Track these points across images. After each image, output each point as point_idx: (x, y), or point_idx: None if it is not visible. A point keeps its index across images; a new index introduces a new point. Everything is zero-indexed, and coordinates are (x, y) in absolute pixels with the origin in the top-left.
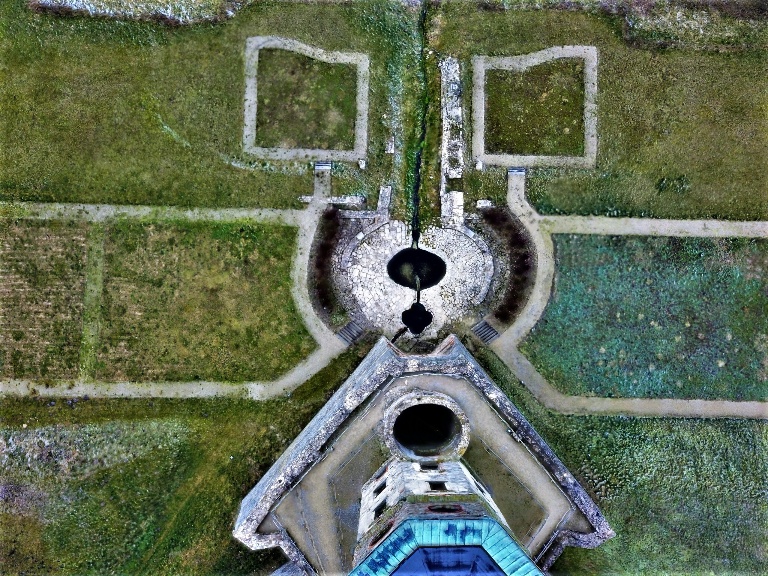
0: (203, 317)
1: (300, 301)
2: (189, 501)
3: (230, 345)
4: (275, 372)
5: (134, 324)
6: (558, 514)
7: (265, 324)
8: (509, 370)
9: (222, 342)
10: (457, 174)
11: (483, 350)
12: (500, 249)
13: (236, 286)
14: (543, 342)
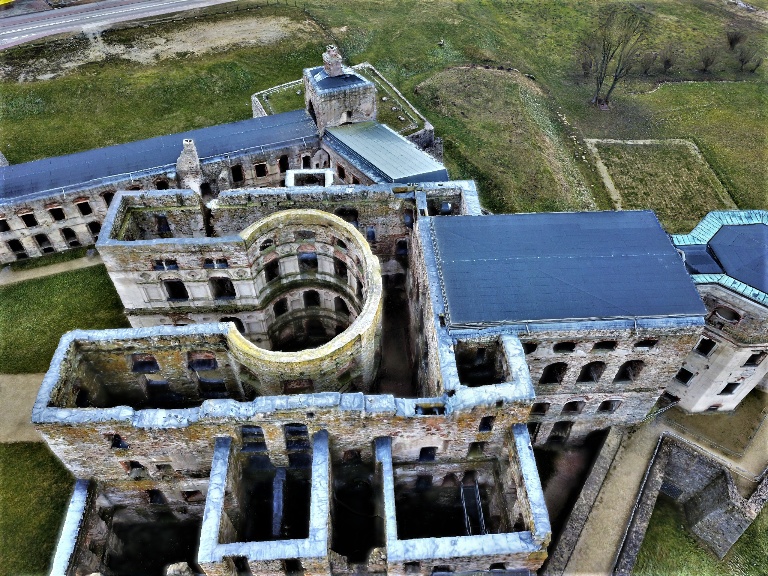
0: None
1: None
2: None
3: None
4: None
5: None
6: None
7: None
8: None
9: None
10: None
11: None
12: None
13: None
14: None
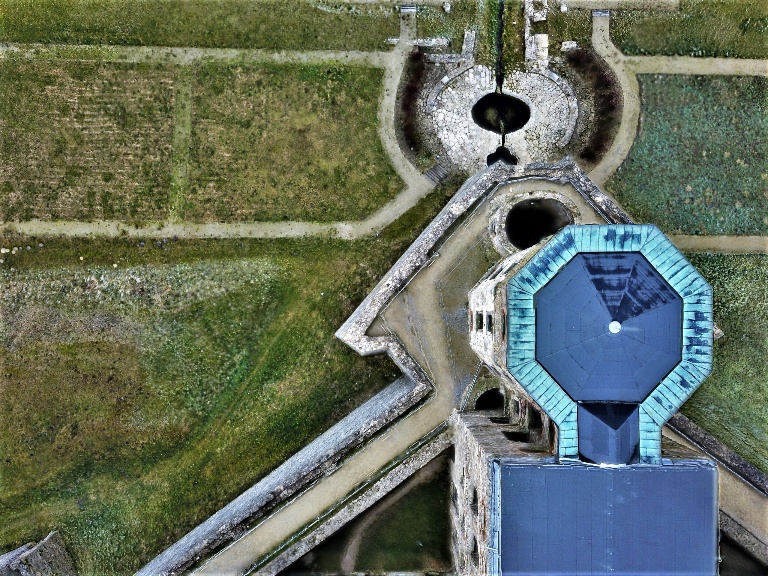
0: (291, 158)
1: (387, 142)
2: (281, 336)
3: (318, 185)
4: (363, 212)
5: (223, 165)
6: None
7: (353, 164)
8: None
9: (310, 182)
10: (542, 17)
11: None
12: (584, 92)
13: (324, 127)
14: (630, 181)
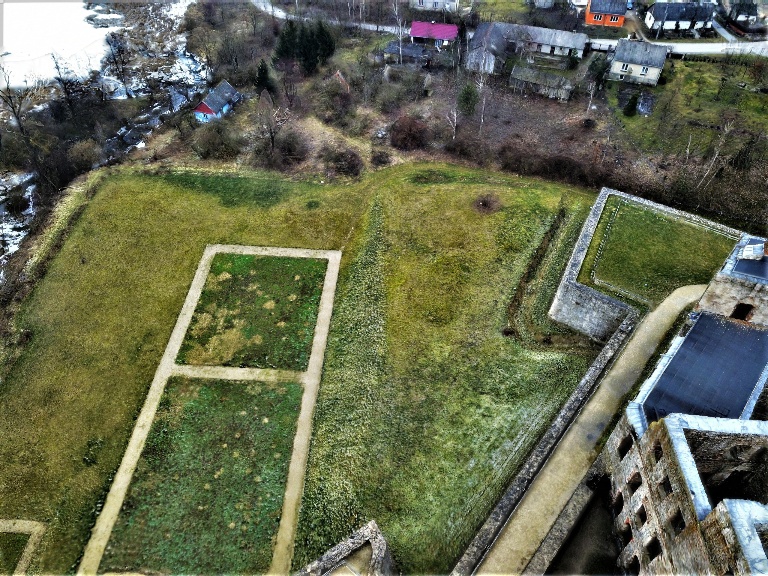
0: None
1: None
2: None
3: None
4: None
5: None
6: None
7: None
8: None
9: None
10: None
11: None
12: None
13: None
14: None
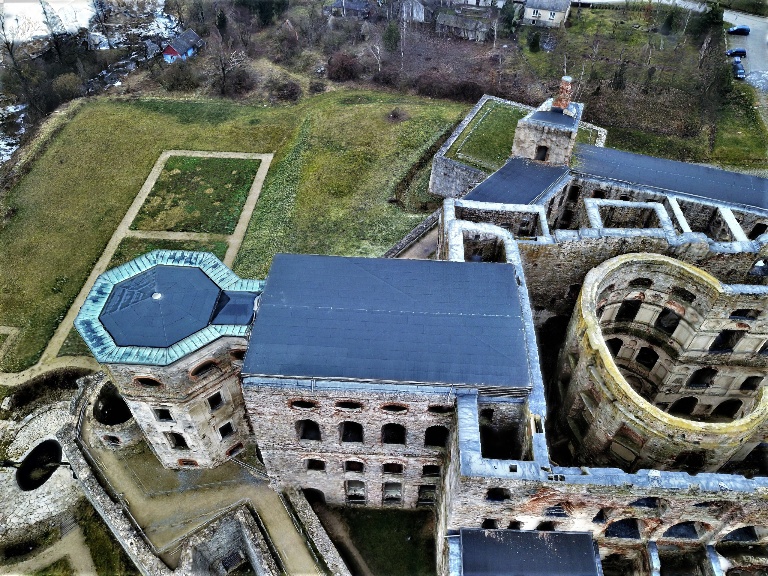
0: None
1: (11, 575)
2: None
3: None
4: None
5: None
6: None
7: None
8: None
9: None
10: None
11: None
12: (54, 396)
13: None
14: None
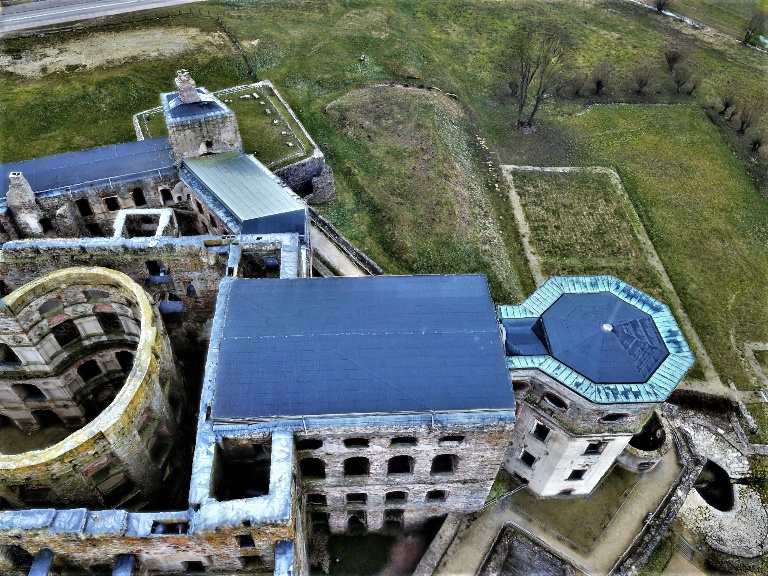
0: None
1: None
2: None
3: None
4: None
5: None
6: (587, 567)
7: None
8: (660, 574)
9: None
10: None
11: (670, 545)
12: None
13: None
14: None
